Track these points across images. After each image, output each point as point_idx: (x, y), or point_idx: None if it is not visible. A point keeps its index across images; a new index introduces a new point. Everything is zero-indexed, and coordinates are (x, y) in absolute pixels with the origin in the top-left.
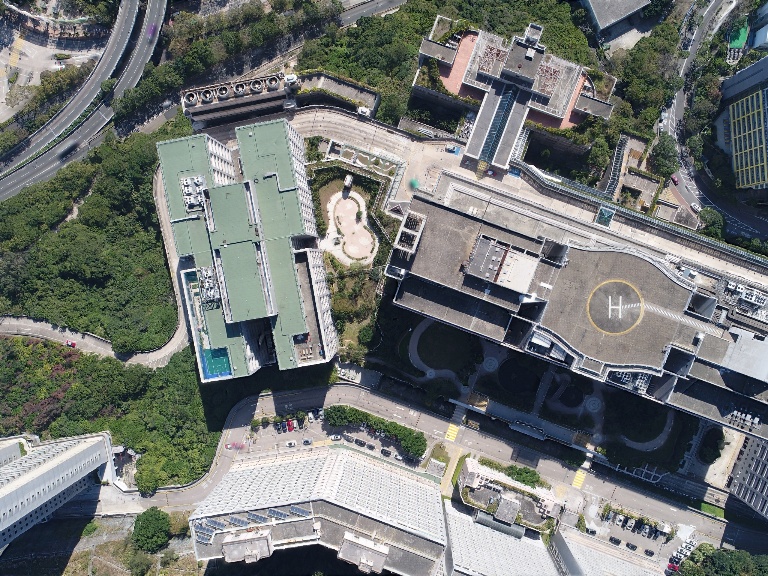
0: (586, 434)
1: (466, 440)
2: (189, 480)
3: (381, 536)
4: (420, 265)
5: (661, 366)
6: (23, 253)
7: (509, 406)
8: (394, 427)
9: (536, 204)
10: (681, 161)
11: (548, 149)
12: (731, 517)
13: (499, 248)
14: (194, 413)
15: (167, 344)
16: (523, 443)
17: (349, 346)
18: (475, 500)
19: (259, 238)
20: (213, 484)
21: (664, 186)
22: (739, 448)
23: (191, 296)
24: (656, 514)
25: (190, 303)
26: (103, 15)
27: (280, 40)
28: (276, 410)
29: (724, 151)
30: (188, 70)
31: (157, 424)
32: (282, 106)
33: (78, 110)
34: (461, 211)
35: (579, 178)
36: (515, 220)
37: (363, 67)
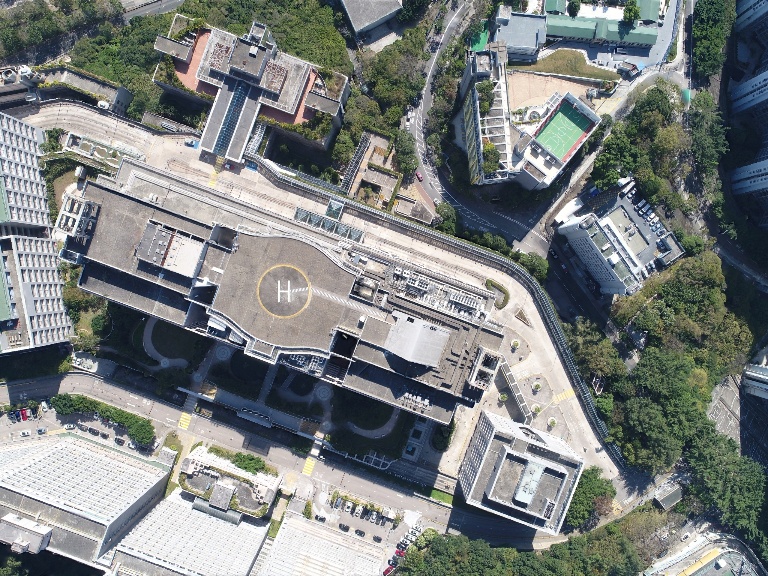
0: (313, 421)
1: (198, 428)
2: None
3: (45, 517)
4: (96, 249)
5: (328, 348)
6: None
7: (236, 394)
8: (119, 415)
9: (214, 191)
10: (426, 158)
11: (299, 145)
12: (459, 503)
13: (165, 233)
14: None
15: None
16: (255, 431)
17: (79, 335)
18: (193, 487)
19: None
20: None
21: (409, 182)
22: (470, 436)
23: None
24: (384, 500)
25: None
26: None
27: (64, 38)
28: (10, 399)
29: (462, 149)
30: None
31: None
32: None
33: None
34: (136, 197)
35: (324, 173)
36: (195, 207)
37: (124, 64)
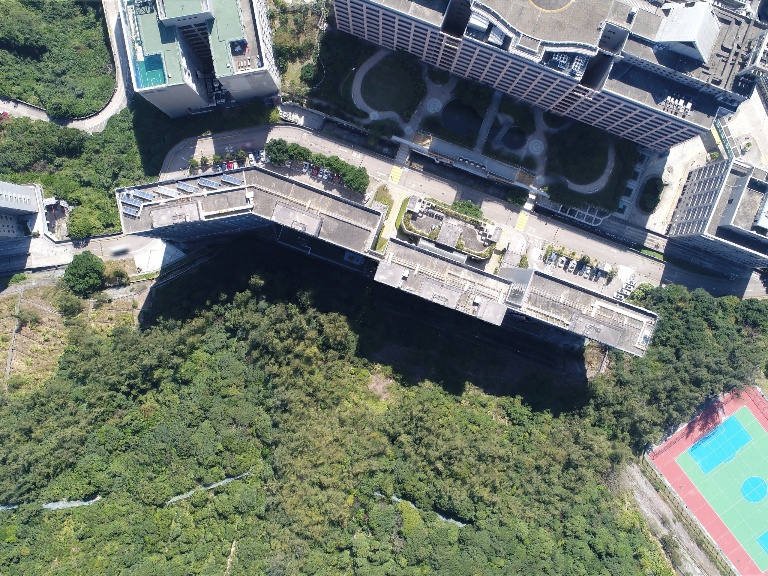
0: (528, 173)
1: (410, 182)
2: None
3: (316, 206)
4: None
5: (596, 43)
6: None
7: (452, 142)
8: (336, 160)
9: None
10: None
11: None
12: (670, 261)
13: None
14: (130, 161)
15: (104, 109)
16: (467, 185)
17: (291, 82)
18: (417, 228)
19: None
20: None
21: None
22: (678, 197)
23: (124, 4)
24: (597, 256)
25: (123, 9)
26: None
27: None
28: (216, 153)
29: None
30: None
31: (92, 179)
32: None
33: None
34: None
35: None
36: None
37: None
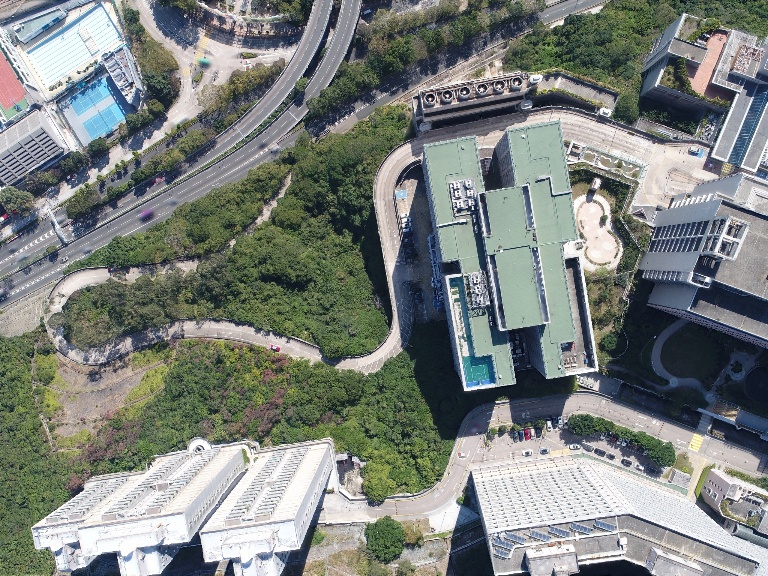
0: None
1: (711, 450)
2: (420, 489)
3: (689, 552)
4: (725, 273)
5: None
6: None
7: (761, 416)
8: (644, 437)
9: None
10: None
11: None
12: None
13: None
14: (422, 420)
15: (378, 349)
16: None
17: None
18: (733, 513)
19: (537, 243)
20: (445, 493)
21: None
22: None
23: (452, 302)
24: None
25: (453, 309)
26: (297, 13)
27: (476, 39)
28: (512, 418)
29: None
30: (385, 69)
31: (378, 431)
32: (514, 107)
33: (267, 110)
34: None
35: None
36: None
37: (584, 67)
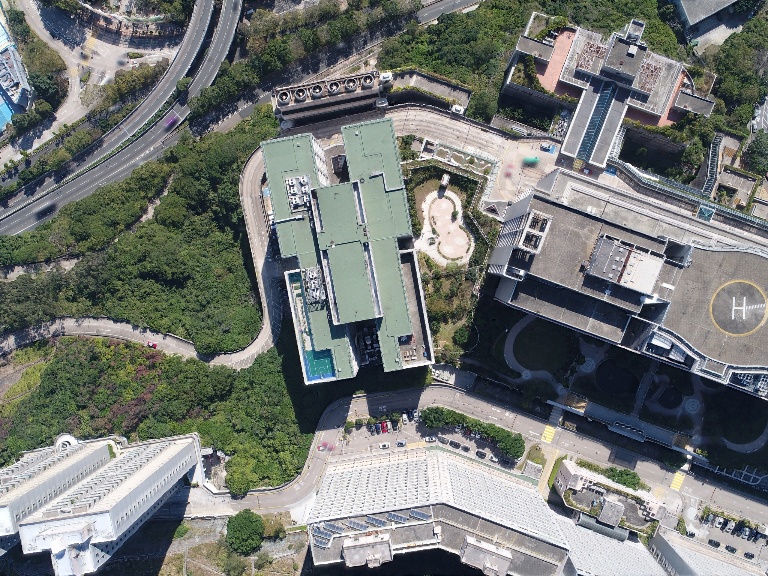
0: (686, 436)
1: (563, 442)
2: (281, 482)
3: (502, 540)
4: (539, 266)
5: None
6: (98, 253)
7: (608, 407)
8: (493, 429)
9: (656, 203)
10: None
11: (639, 147)
12: None
13: (623, 248)
14: (285, 415)
15: (251, 345)
16: (621, 445)
17: (445, 347)
18: (577, 503)
19: (368, 238)
20: (305, 486)
21: None
22: None
23: (293, 297)
24: (756, 516)
25: (293, 304)
26: (178, 13)
27: (356, 38)
28: (369, 412)
29: None
30: (265, 68)
31: (245, 426)
32: (372, 104)
33: (152, 109)
34: (581, 211)
35: (672, 176)
36: (634, 220)
37: (449, 65)
